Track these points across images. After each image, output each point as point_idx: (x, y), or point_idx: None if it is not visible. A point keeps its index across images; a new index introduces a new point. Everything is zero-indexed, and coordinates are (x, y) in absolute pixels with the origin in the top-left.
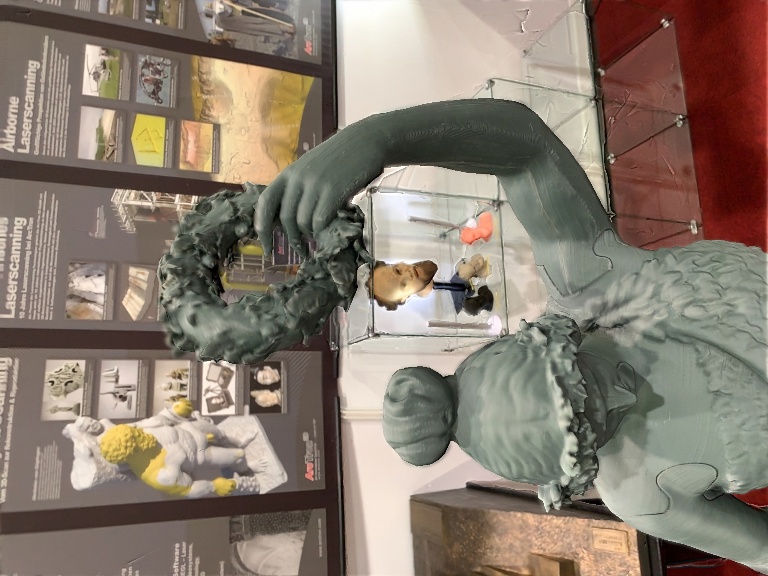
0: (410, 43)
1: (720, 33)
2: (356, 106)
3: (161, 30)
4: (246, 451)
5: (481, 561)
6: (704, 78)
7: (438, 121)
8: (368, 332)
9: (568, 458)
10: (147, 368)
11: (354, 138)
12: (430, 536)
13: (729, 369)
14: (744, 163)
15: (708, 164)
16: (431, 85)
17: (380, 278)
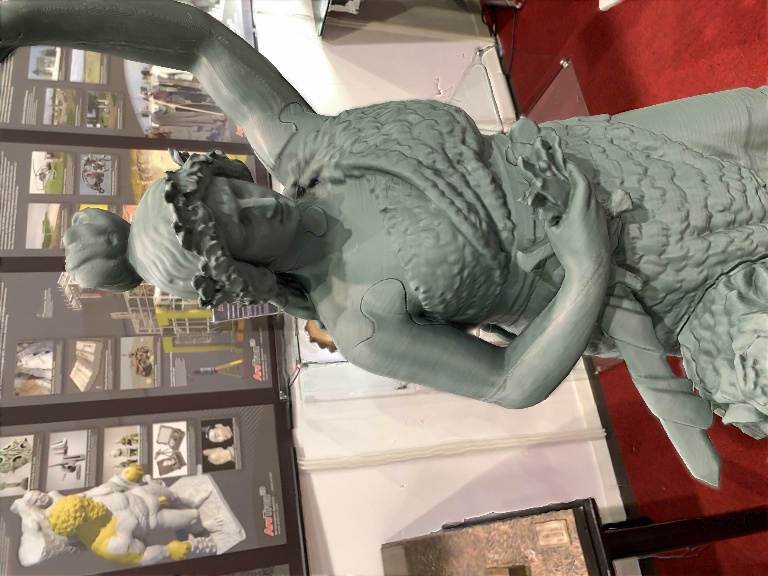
0: None
1: (609, 60)
2: None
3: (101, 132)
4: (200, 511)
5: None
6: (605, 101)
7: (79, 2)
8: (296, 363)
9: (171, 226)
10: (96, 437)
11: None
12: None
13: (392, 188)
14: None
15: None
16: None
17: None
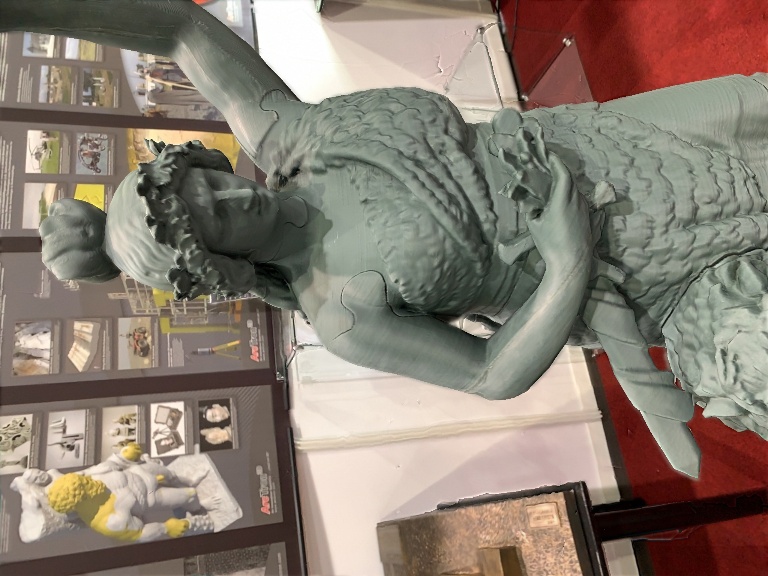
0: (335, 95)
1: (612, 39)
2: None
3: (97, 111)
4: (198, 490)
5: (437, 570)
6: (607, 81)
7: None
8: (292, 346)
9: None
10: (94, 416)
11: None
12: (393, 558)
13: (373, 178)
14: None
15: None
16: None
17: None
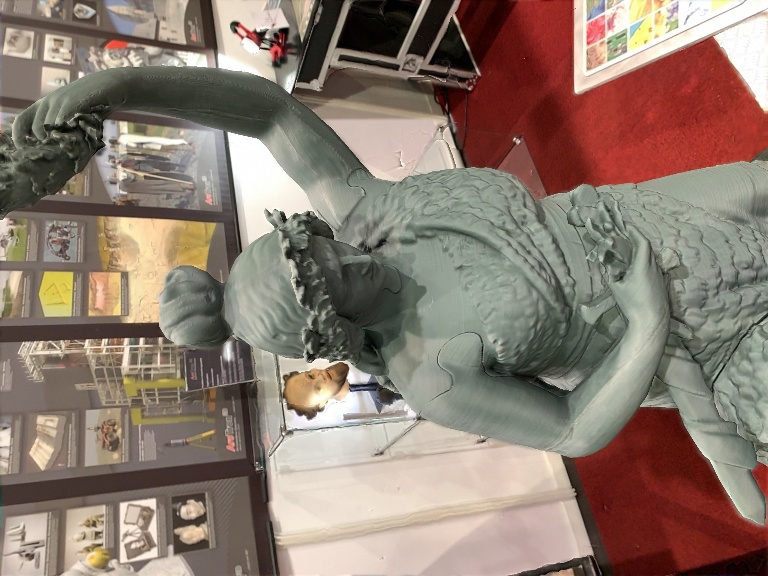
0: None
1: (559, 138)
2: None
3: (67, 199)
4: None
5: None
6: (557, 175)
7: (175, 72)
8: (281, 431)
9: (291, 281)
10: (57, 520)
11: (95, 74)
12: None
13: (466, 247)
14: None
15: None
16: None
17: (294, 386)
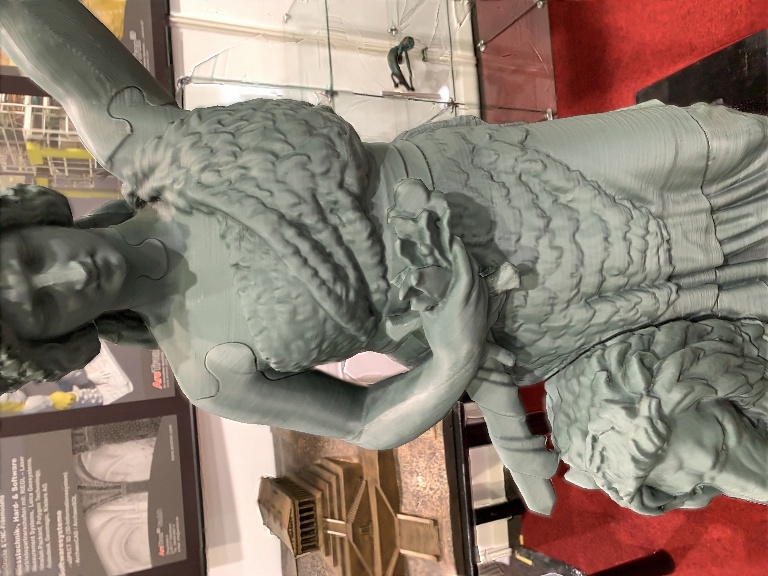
0: None
1: None
2: None
3: None
4: None
5: (320, 454)
6: None
7: None
8: None
9: None
10: None
11: None
12: (282, 434)
13: (247, 240)
14: (593, 45)
15: (563, 48)
16: None
17: None
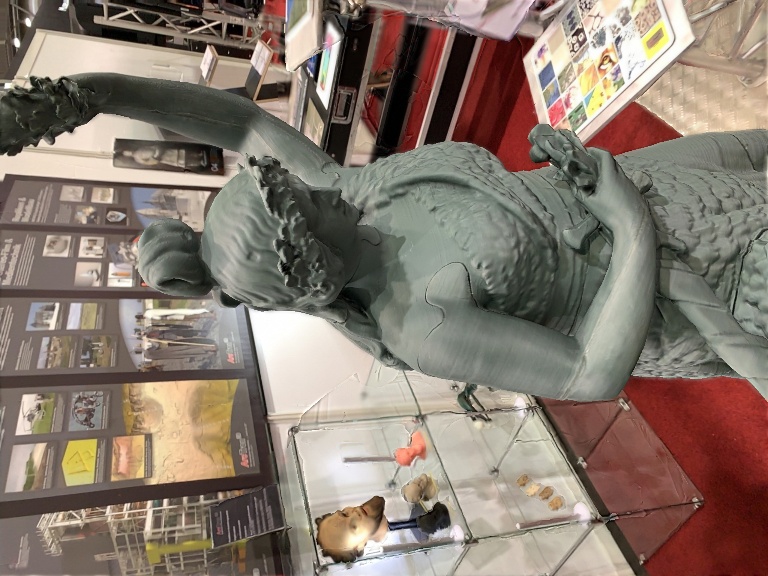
0: (322, 338)
1: None
2: (282, 394)
3: (94, 371)
4: None
5: None
6: None
7: (156, 80)
8: (314, 568)
9: (256, 183)
10: None
11: None
12: None
13: (437, 192)
14: None
15: None
16: (347, 362)
17: (327, 527)
